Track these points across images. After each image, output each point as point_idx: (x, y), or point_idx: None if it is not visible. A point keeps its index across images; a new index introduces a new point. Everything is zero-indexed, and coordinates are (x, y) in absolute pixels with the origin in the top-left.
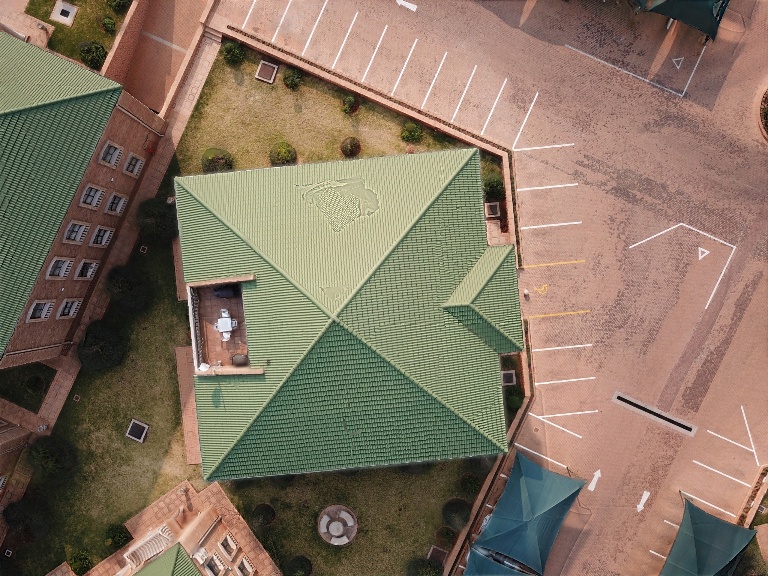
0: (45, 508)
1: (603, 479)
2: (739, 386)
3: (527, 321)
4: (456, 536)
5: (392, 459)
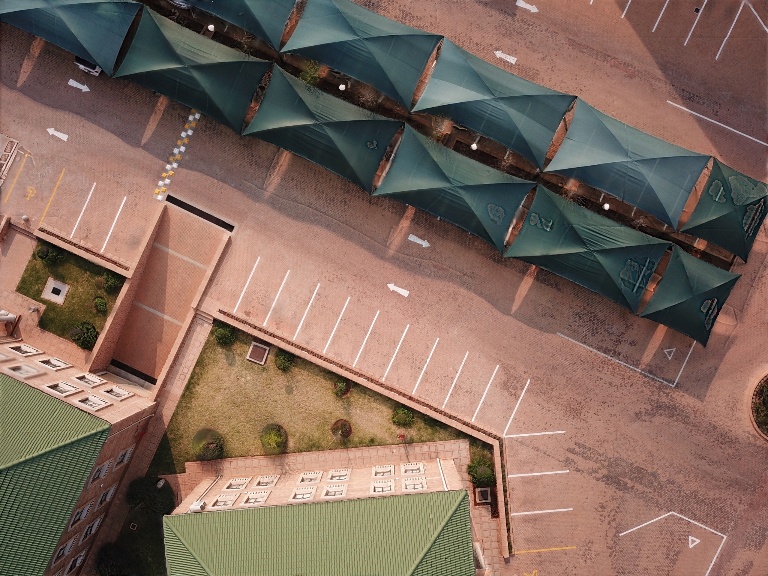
0: None
1: None
2: None
3: None
4: None
5: None
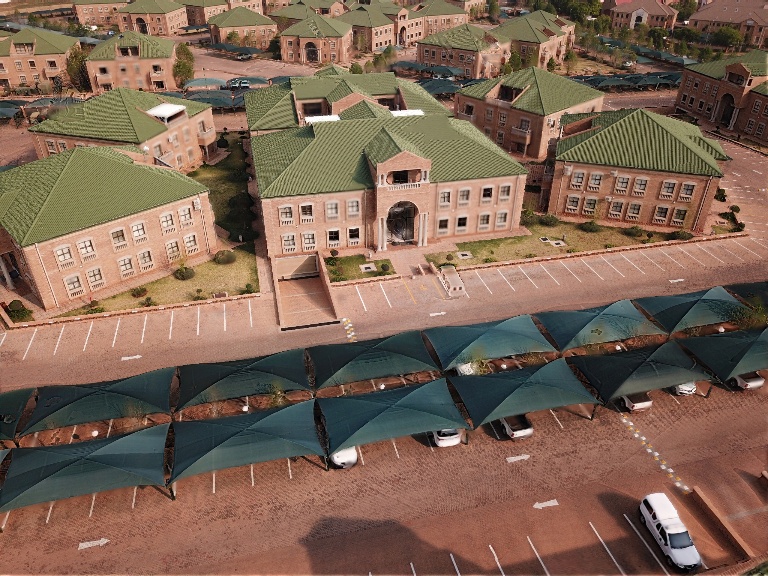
0: None
1: None
2: None
3: None
4: None
5: None
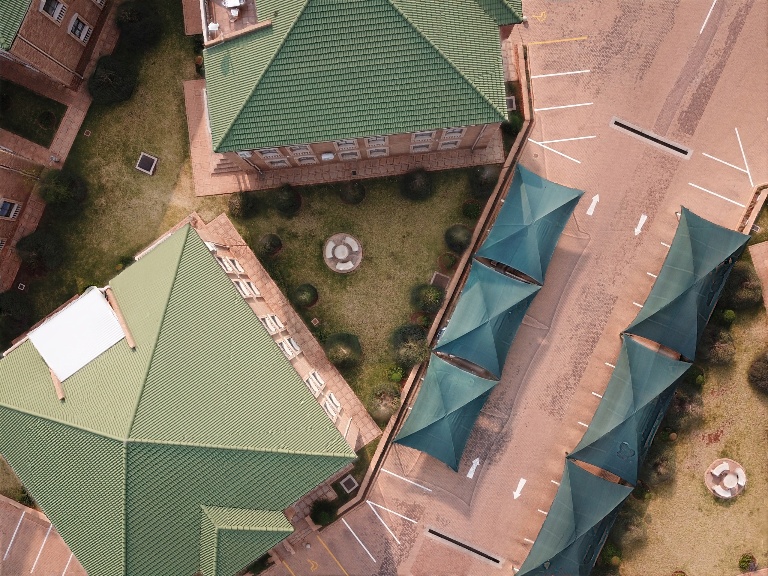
0: (57, 240)
1: (601, 204)
2: (733, 108)
3: (526, 47)
4: (458, 261)
5: (396, 127)
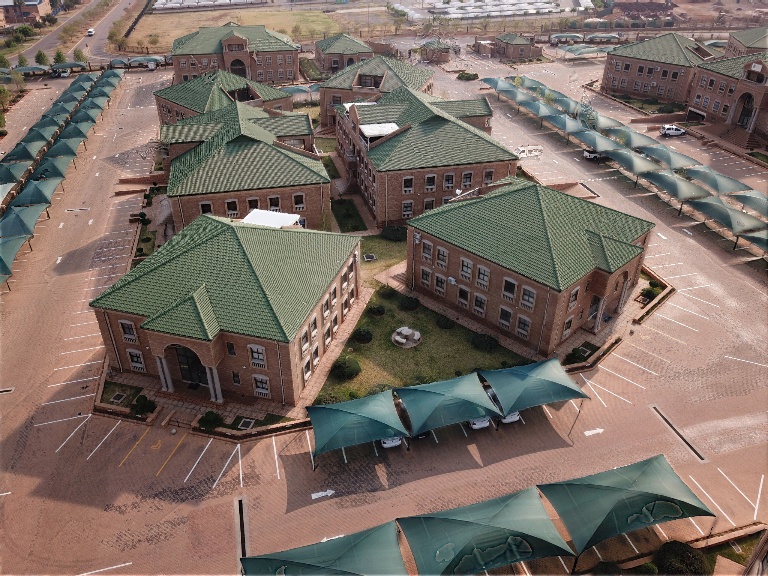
0: None
1: (601, 436)
2: None
3: (621, 340)
4: None
5: (497, 259)
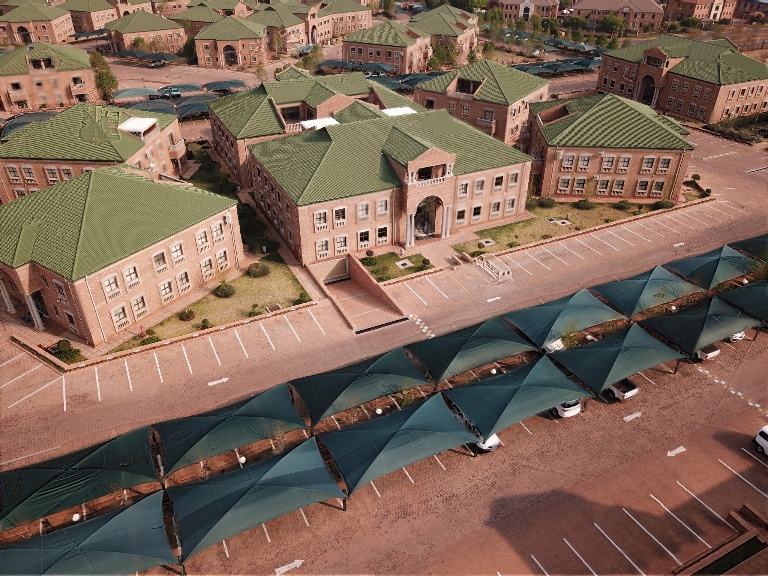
0: (213, 181)
1: None
2: None
3: None
4: None
5: None
